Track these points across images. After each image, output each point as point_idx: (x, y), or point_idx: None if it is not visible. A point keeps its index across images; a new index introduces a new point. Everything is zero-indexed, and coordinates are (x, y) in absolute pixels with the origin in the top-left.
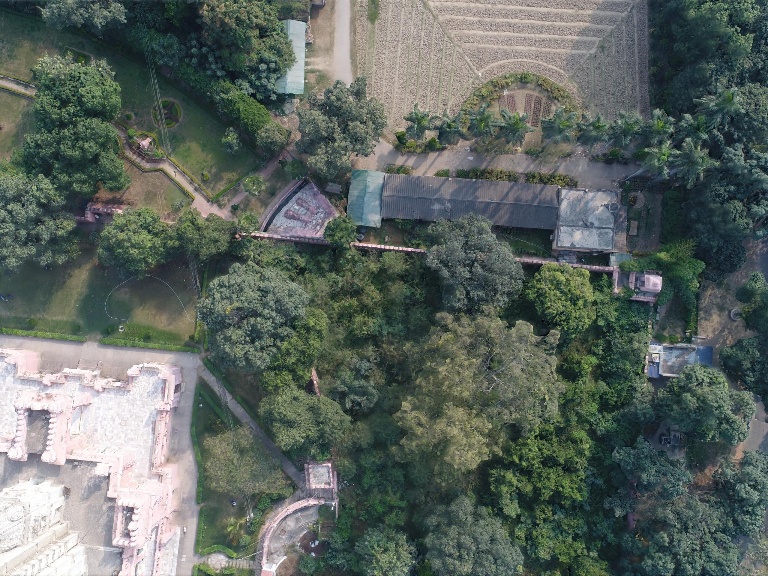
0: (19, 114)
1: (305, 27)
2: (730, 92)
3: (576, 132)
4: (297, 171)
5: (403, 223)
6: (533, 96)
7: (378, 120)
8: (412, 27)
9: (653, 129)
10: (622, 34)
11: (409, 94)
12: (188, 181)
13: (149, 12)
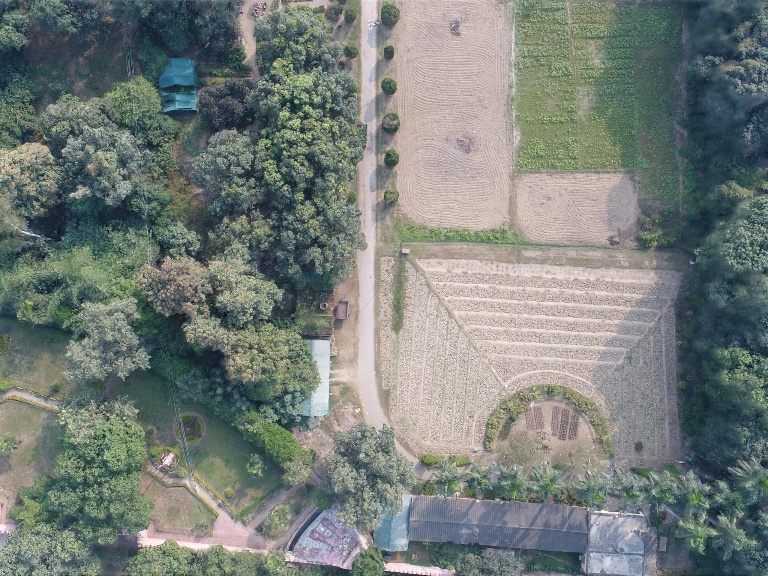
0: (39, 427)
1: (329, 345)
2: (767, 474)
3: (604, 447)
4: (324, 506)
5: (430, 545)
6: (560, 408)
7: (408, 481)
8: (437, 337)
9: (687, 497)
10: (650, 345)
11: (435, 406)
12: (211, 497)
13: (172, 341)
